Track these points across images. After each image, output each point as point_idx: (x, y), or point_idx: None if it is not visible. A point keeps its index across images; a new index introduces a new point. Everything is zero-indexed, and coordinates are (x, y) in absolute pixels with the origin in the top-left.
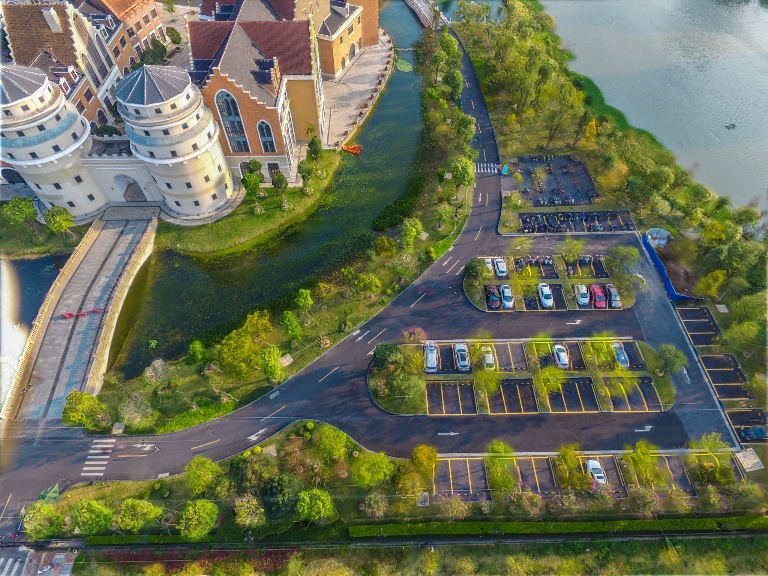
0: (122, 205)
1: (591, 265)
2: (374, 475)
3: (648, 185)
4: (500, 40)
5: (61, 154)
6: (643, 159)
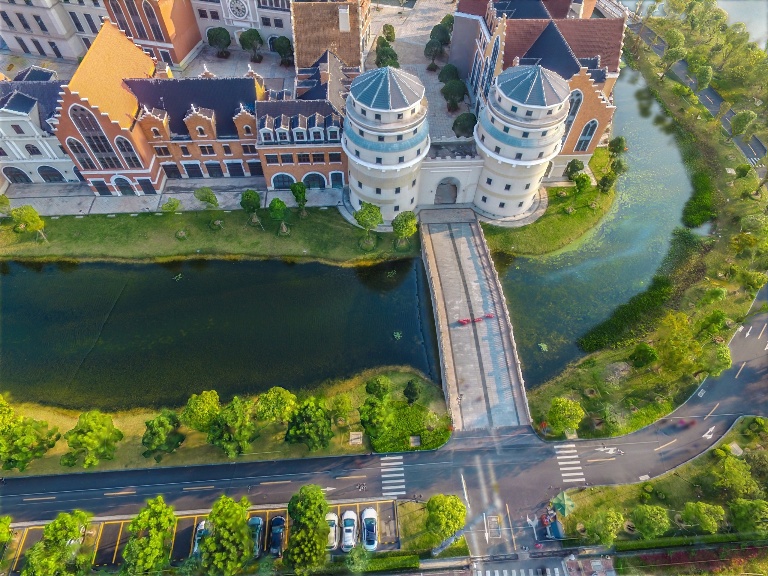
0: (433, 208)
1: None
2: None
3: None
4: (733, 35)
5: (420, 157)
6: None
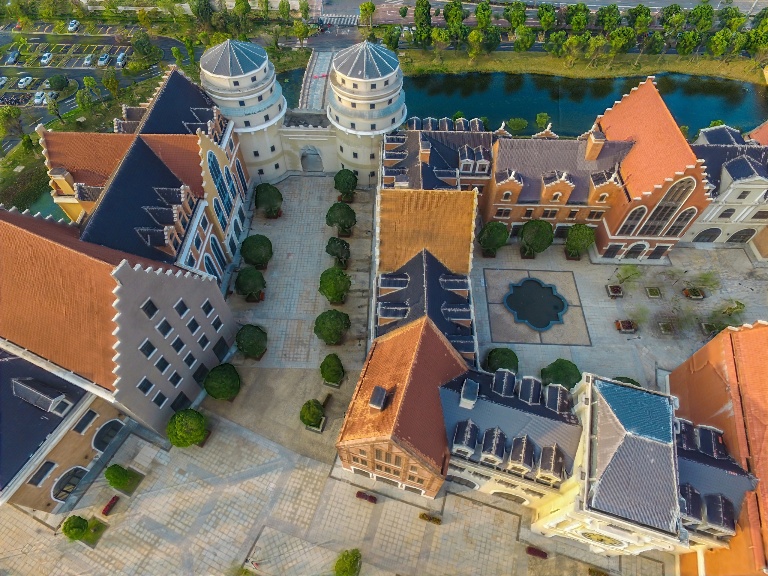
0: None
1: None
2: None
3: None
4: None
5: None
6: None
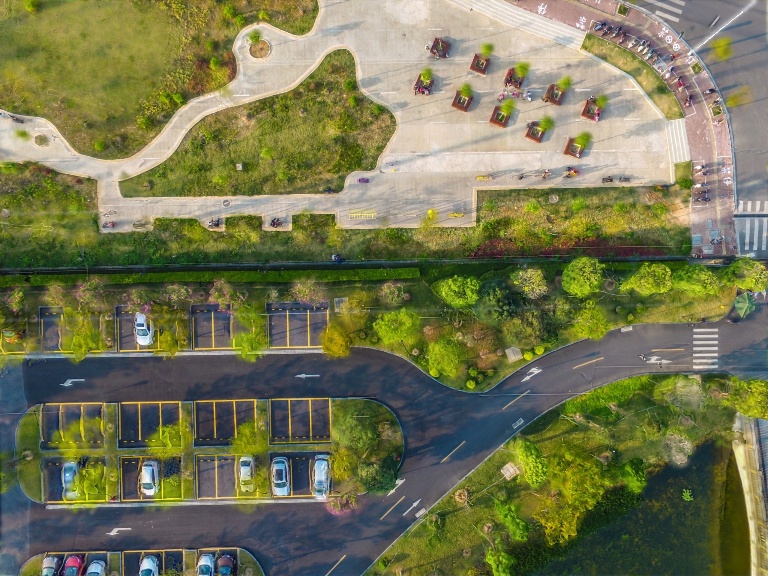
0: None
1: None
2: (395, 318)
3: None
4: None
5: None
6: None
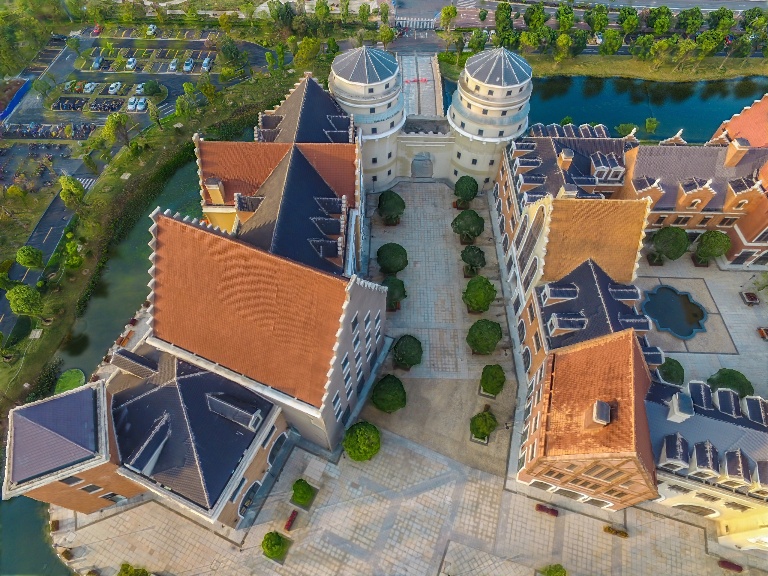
0: None
1: None
2: (247, 5)
3: None
4: None
5: None
6: None
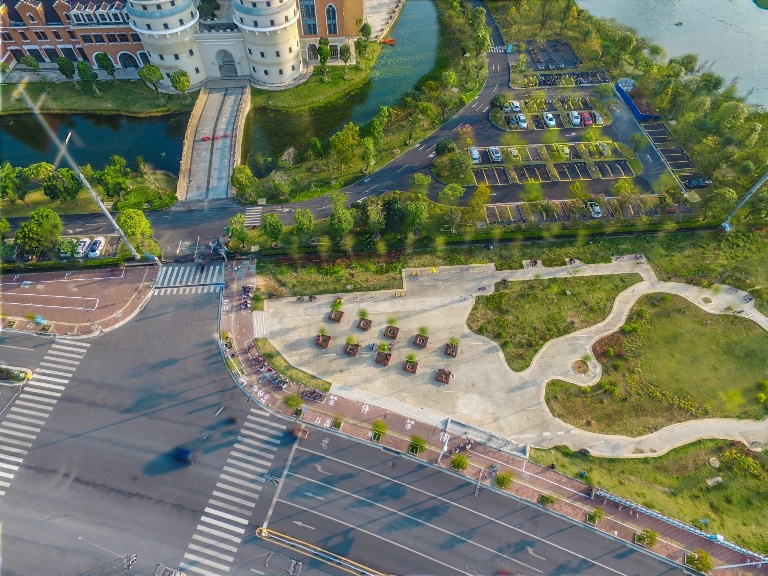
0: (219, 79)
1: (580, 103)
2: (454, 192)
3: (617, 47)
4: None
5: (184, 27)
6: (613, 31)
